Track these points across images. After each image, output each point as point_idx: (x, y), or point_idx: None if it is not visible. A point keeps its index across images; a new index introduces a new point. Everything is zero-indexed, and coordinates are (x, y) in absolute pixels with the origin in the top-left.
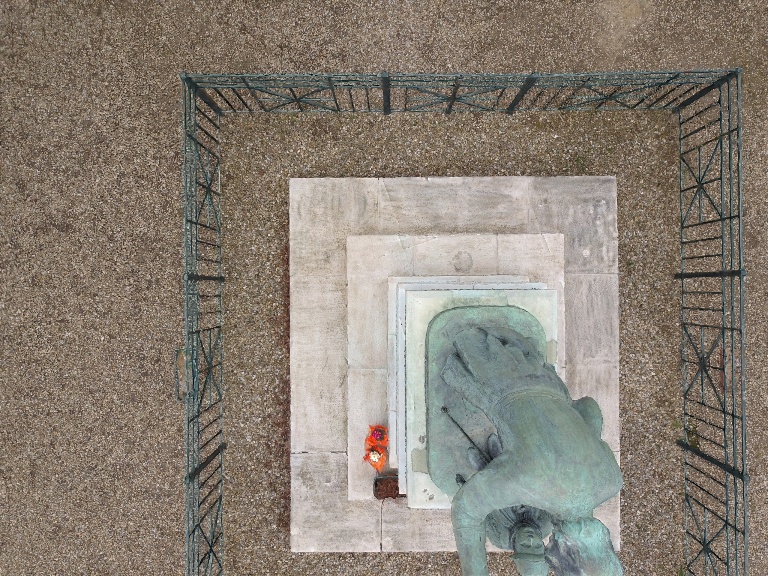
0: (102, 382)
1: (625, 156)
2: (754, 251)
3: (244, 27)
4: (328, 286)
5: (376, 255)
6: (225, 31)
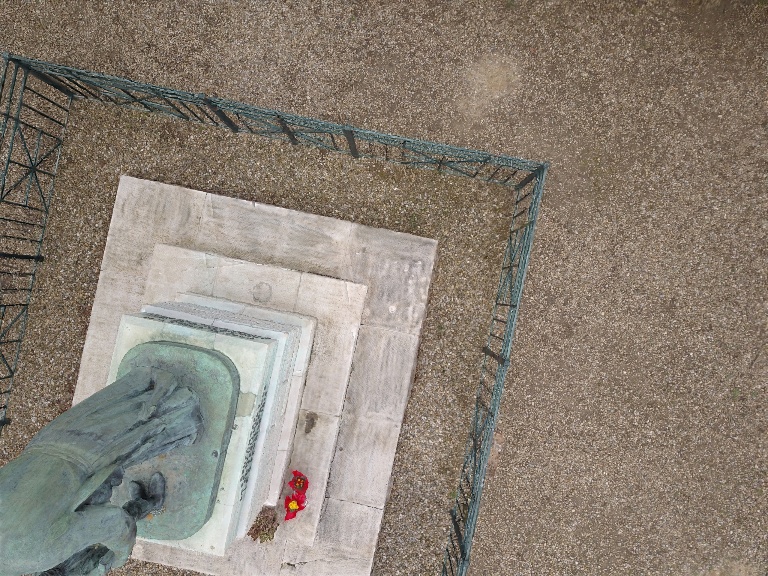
0: None
1: (459, 222)
2: (567, 341)
3: (117, 18)
4: (135, 288)
5: (179, 268)
6: (98, 18)
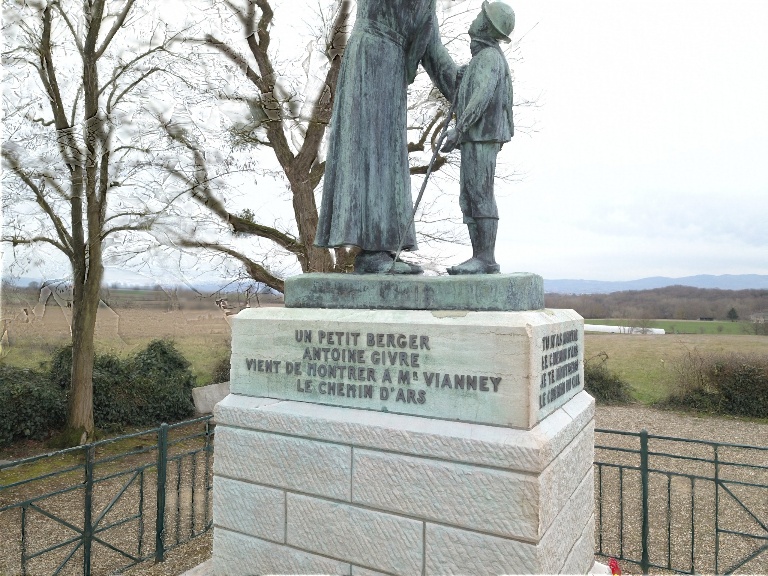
0: None
1: None
2: None
3: None
4: None
5: None
6: None
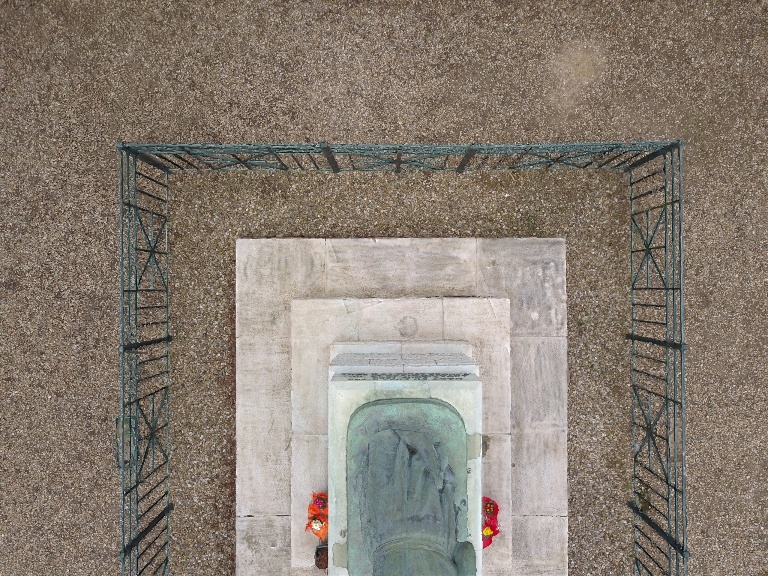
0: (49, 441)
1: (576, 215)
2: (706, 311)
3: (193, 83)
4: (274, 348)
5: (320, 320)
6: (174, 87)
